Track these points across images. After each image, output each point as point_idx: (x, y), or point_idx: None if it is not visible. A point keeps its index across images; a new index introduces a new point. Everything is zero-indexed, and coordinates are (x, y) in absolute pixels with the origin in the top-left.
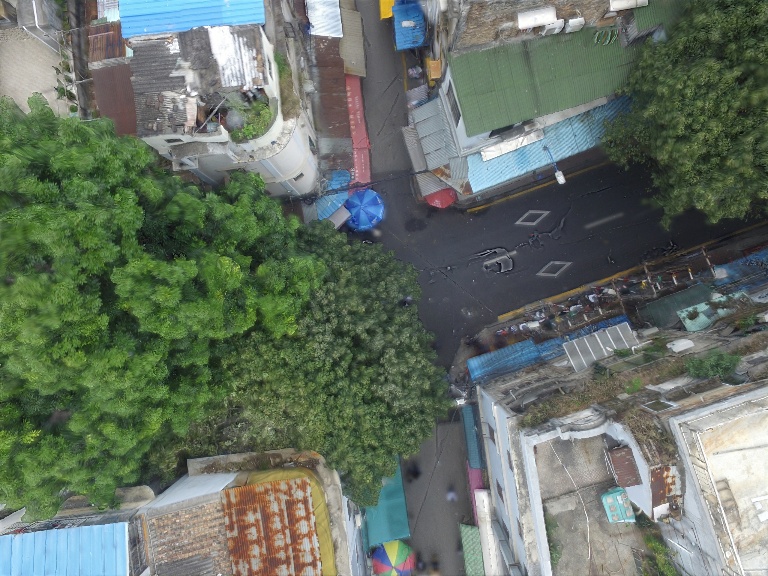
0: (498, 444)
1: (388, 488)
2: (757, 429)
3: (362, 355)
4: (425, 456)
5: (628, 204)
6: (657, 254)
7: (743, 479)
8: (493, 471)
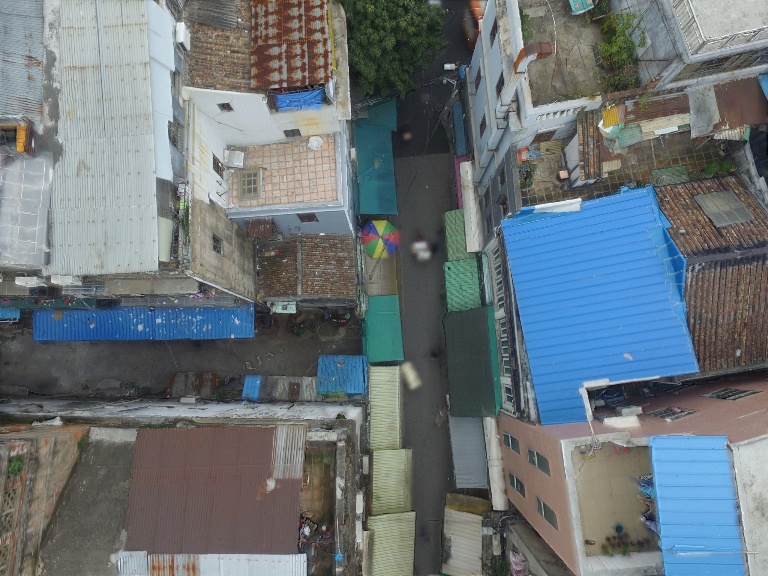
0: None
1: (381, 172)
2: None
3: None
4: (416, 182)
5: None
6: None
7: None
8: (477, 128)
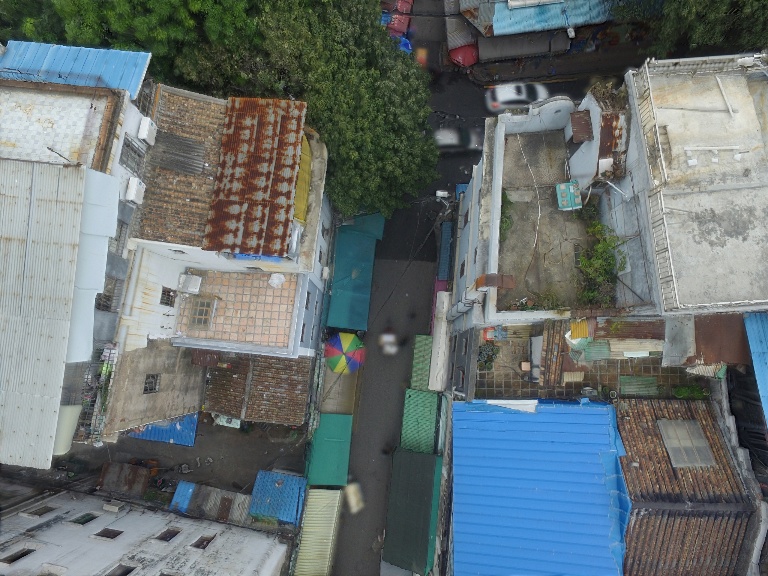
0: (471, 203)
1: (357, 283)
2: (698, 98)
3: None
4: (396, 287)
5: None
6: None
7: (680, 132)
8: None
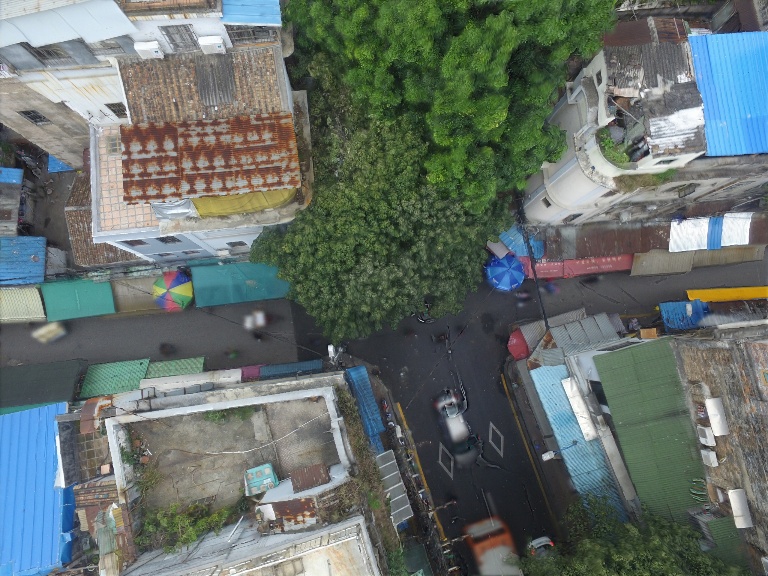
0: None
1: (243, 287)
2: None
3: (396, 247)
4: (265, 328)
5: (517, 532)
6: (461, 568)
7: None
8: None
